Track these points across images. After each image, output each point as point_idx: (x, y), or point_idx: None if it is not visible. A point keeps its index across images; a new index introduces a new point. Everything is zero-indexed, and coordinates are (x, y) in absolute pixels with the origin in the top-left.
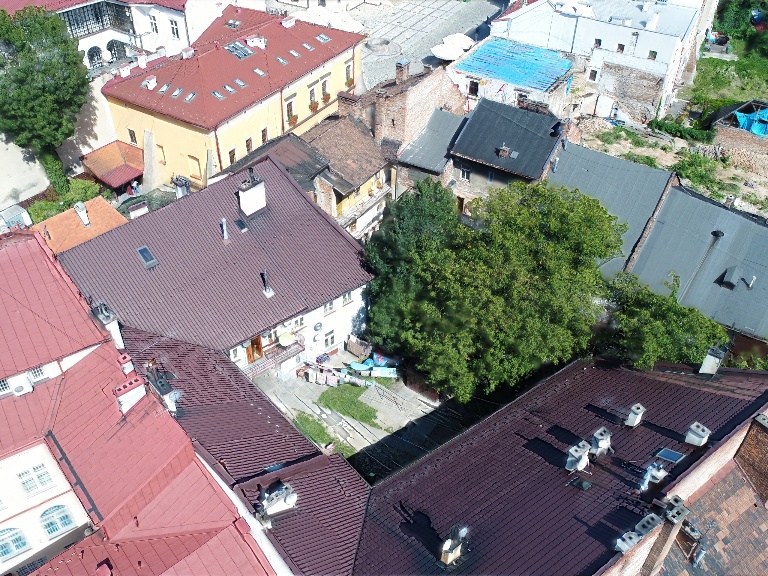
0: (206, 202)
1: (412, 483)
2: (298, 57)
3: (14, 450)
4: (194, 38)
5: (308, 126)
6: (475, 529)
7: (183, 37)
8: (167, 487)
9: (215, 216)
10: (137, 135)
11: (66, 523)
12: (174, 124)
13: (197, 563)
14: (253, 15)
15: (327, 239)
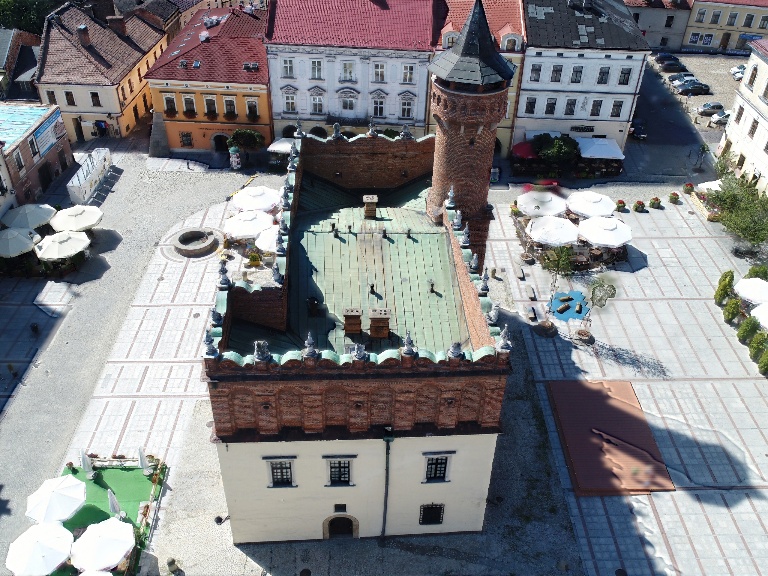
0: None
1: None
2: None
3: None
4: None
5: None
6: None
7: None
8: None
9: None
10: None
11: None
12: None
13: None
14: None
15: None
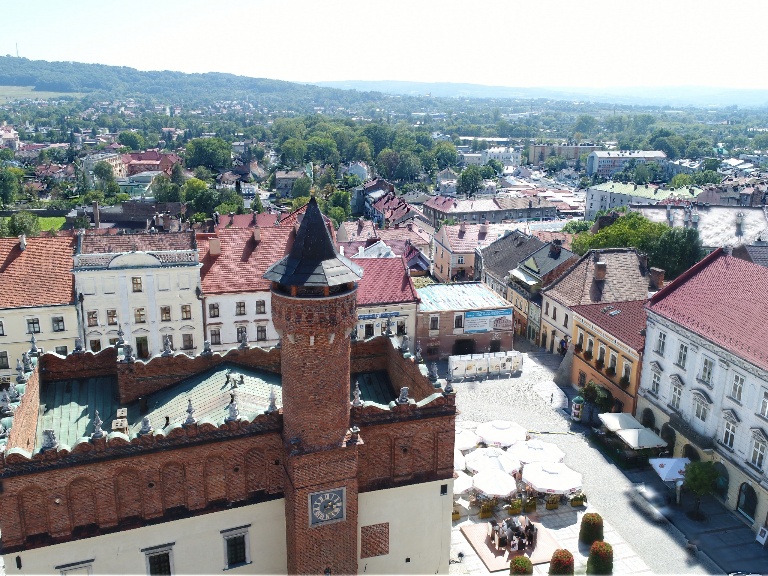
0: None
1: (732, 243)
2: None
3: None
4: None
5: None
6: (729, 225)
7: None
8: None
9: None
10: None
11: None
12: None
13: None
14: None
15: None
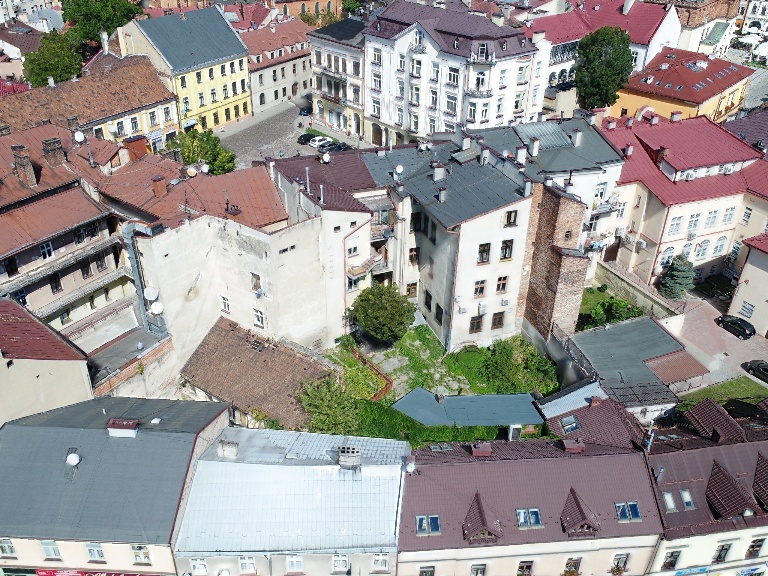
0: (759, 120)
1: None
2: (725, 76)
3: (736, 192)
4: (647, 63)
5: (720, 121)
6: None
7: (640, 62)
8: None
9: (765, 127)
10: (629, 112)
11: None
12: (667, 103)
13: None
14: (684, 52)
15: None
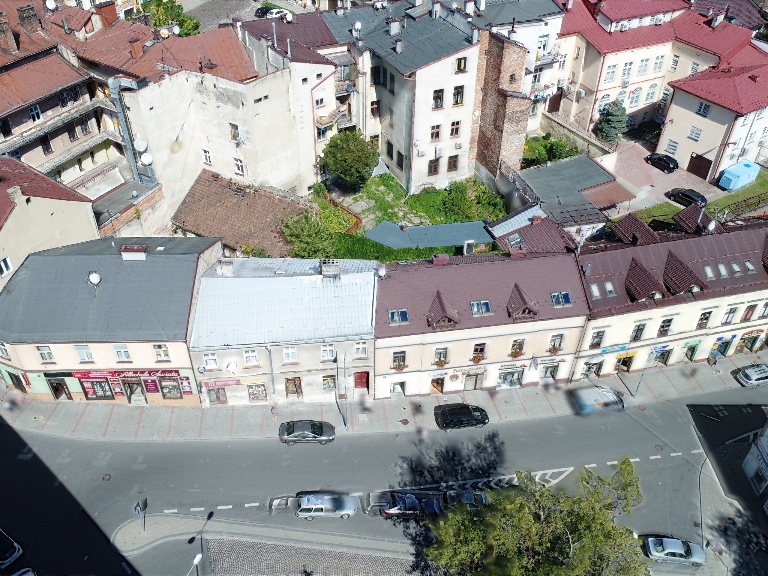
0: None
1: None
2: None
3: (665, 40)
4: None
5: None
6: None
7: None
8: (739, 53)
9: None
10: None
11: (652, 97)
12: None
13: (766, 70)
14: None
15: (743, 2)
